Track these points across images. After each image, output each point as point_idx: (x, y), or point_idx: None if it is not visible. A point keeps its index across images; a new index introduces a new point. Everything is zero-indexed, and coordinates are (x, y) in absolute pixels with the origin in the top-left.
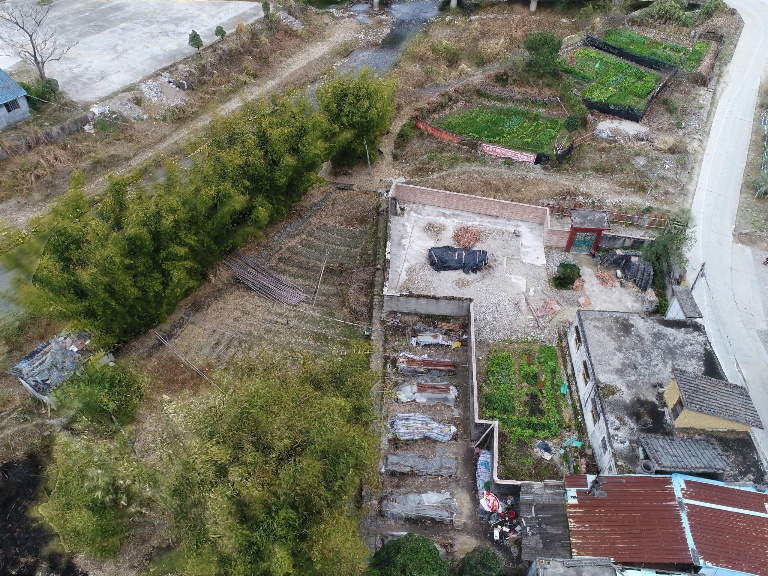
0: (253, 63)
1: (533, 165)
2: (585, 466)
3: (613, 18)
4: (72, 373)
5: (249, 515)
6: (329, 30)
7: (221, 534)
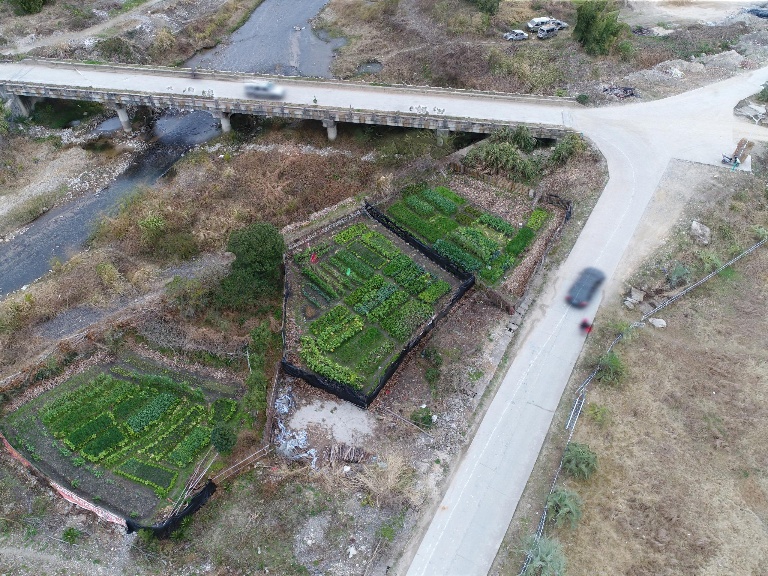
0: None
1: (123, 535)
2: None
3: (417, 168)
4: None
5: None
6: (33, 172)
7: None
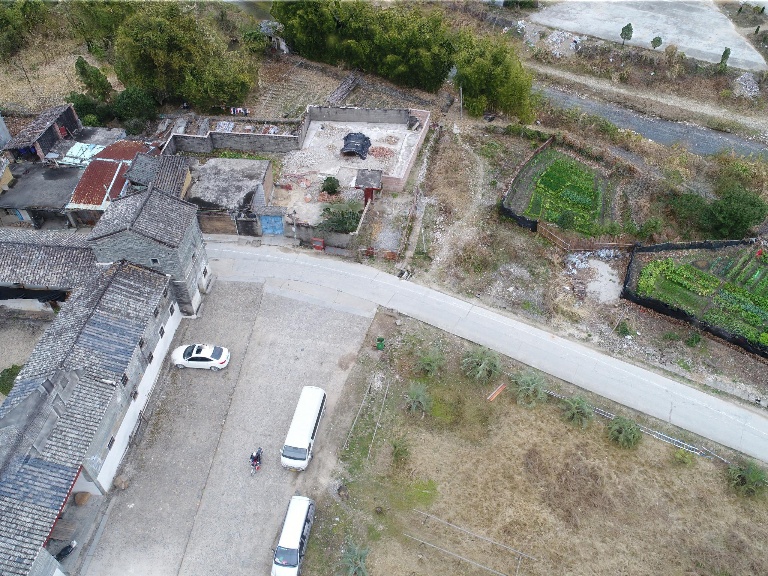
0: (644, 76)
1: None
2: None
3: None
4: (266, 33)
5: None
6: (762, 114)
7: None
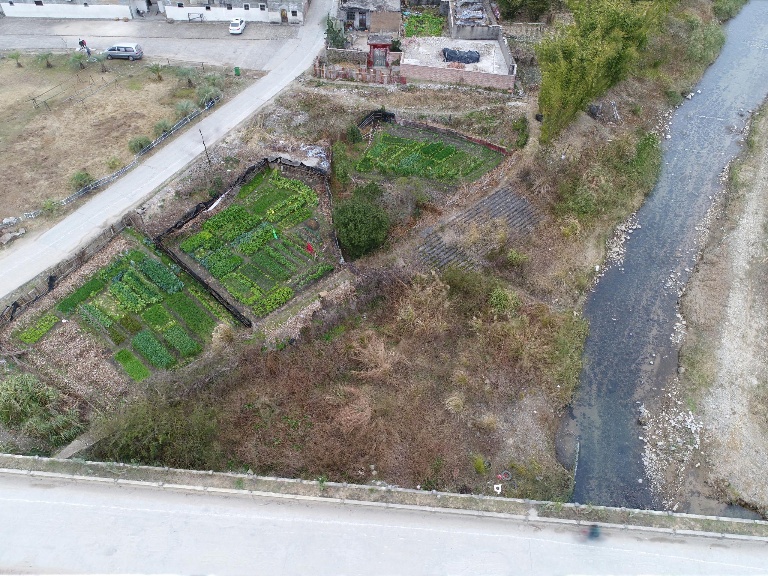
0: None
1: None
2: (406, 1)
3: None
4: None
5: None
6: None
7: None
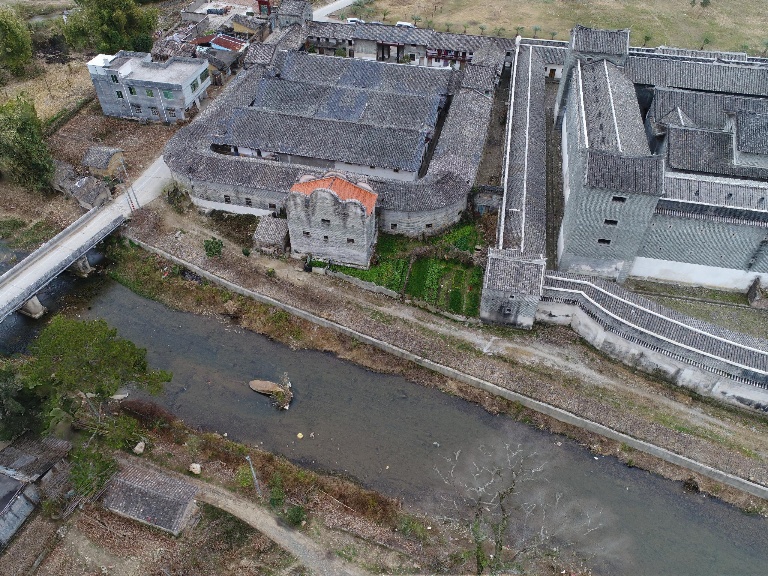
0: None
1: None
2: None
3: None
4: None
5: (100, 7)
6: None
7: (93, 7)
